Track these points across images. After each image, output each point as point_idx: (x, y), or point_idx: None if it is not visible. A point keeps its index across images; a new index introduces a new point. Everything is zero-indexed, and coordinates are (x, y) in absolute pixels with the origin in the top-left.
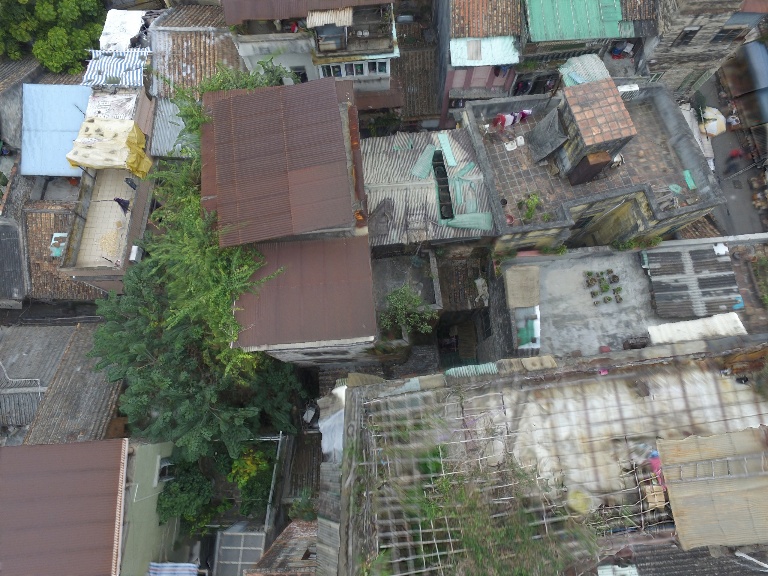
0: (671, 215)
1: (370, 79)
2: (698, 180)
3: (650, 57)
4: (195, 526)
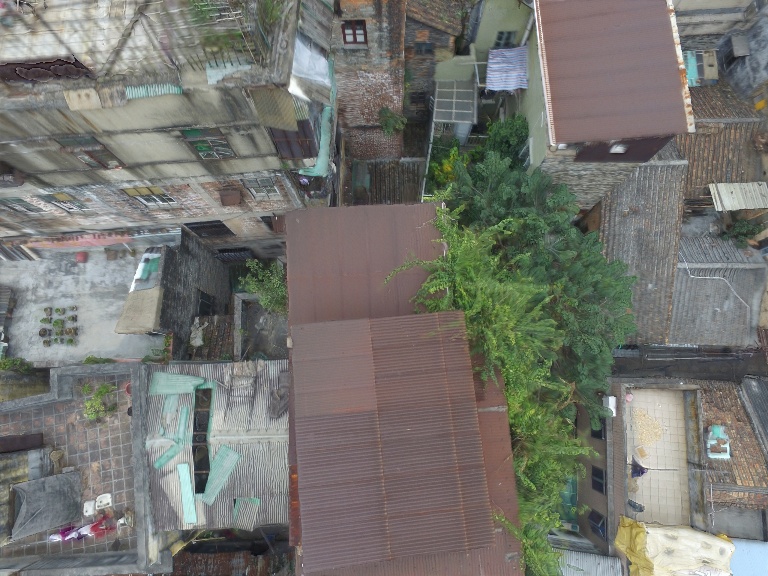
0: None
1: None
2: None
3: None
4: None
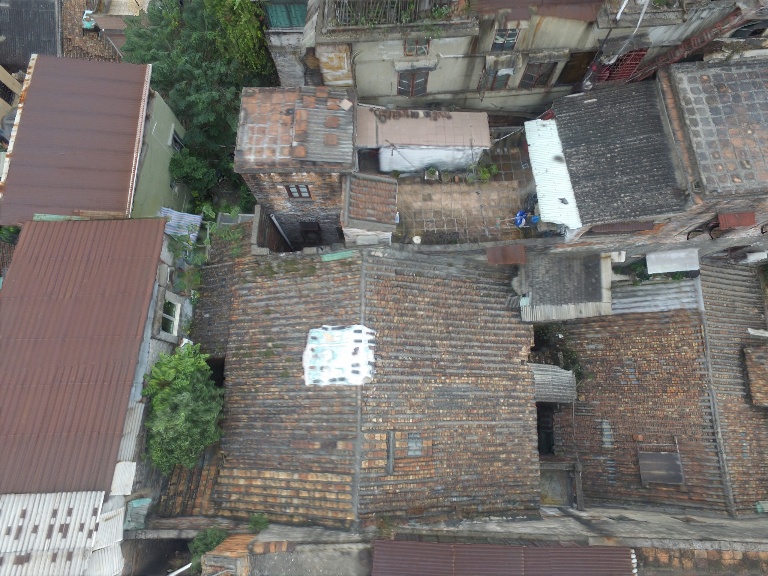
0: None
1: None
2: None
3: None
4: (200, 207)
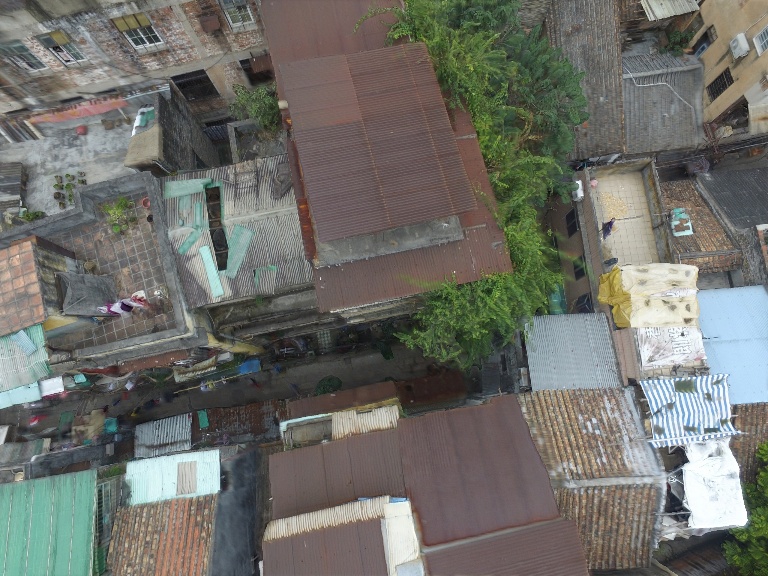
0: None
1: None
2: None
3: None
4: None
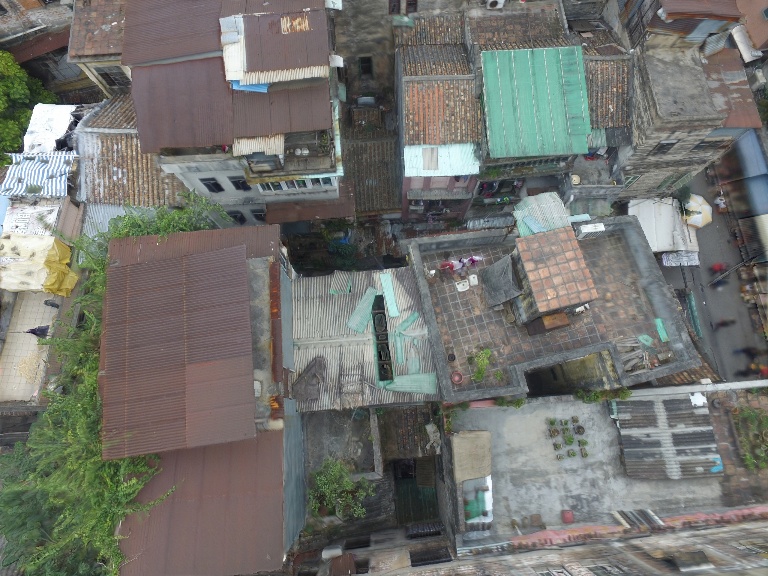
0: (638, 382)
1: (315, 191)
2: (671, 333)
3: (625, 164)
4: None
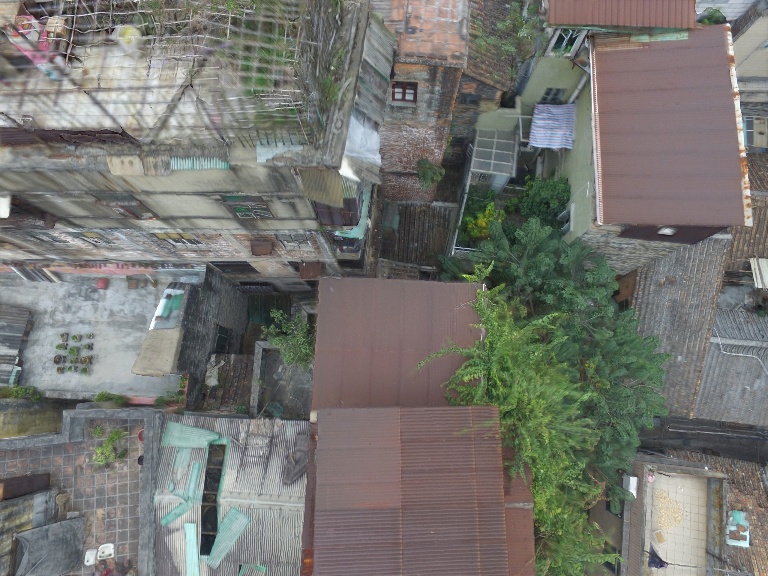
0: None
1: None
2: None
3: None
4: None
